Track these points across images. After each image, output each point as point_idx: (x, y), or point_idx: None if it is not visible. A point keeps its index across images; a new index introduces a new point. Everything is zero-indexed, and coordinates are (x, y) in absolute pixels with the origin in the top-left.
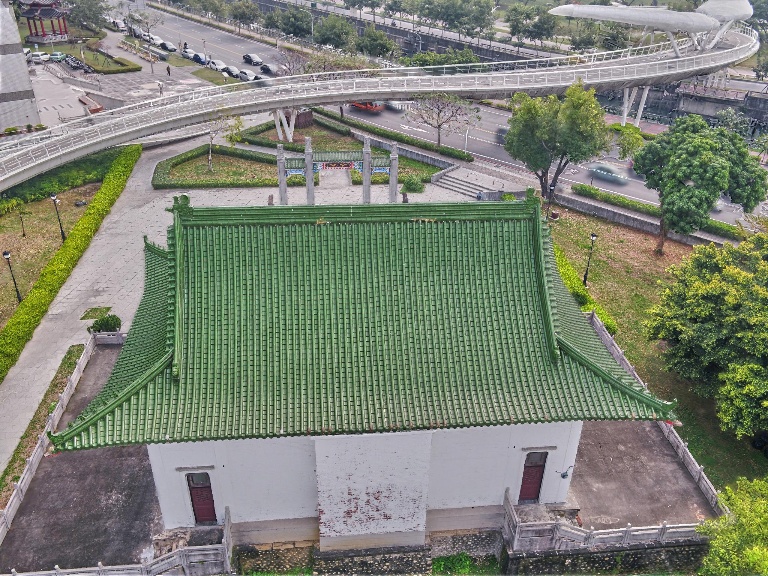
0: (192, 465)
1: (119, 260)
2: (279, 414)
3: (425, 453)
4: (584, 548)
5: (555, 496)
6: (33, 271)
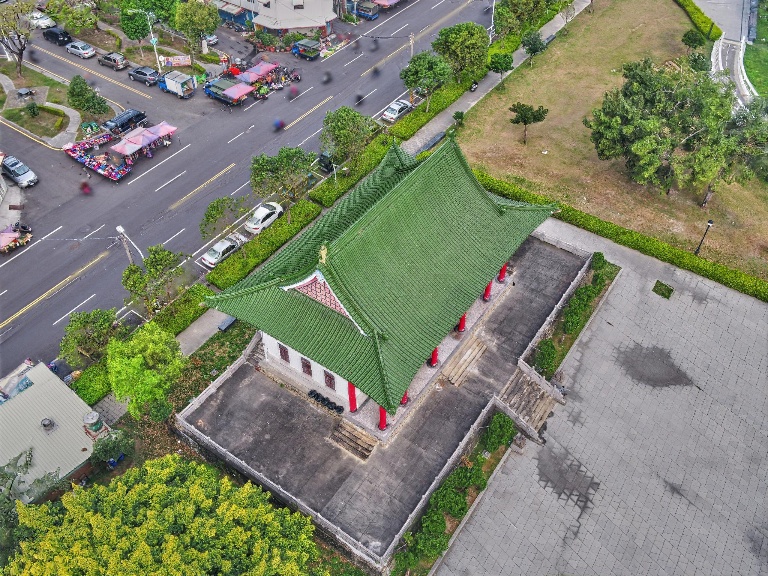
0: None
1: (760, 327)
2: (355, 198)
3: None
4: None
5: None
6: (763, 277)
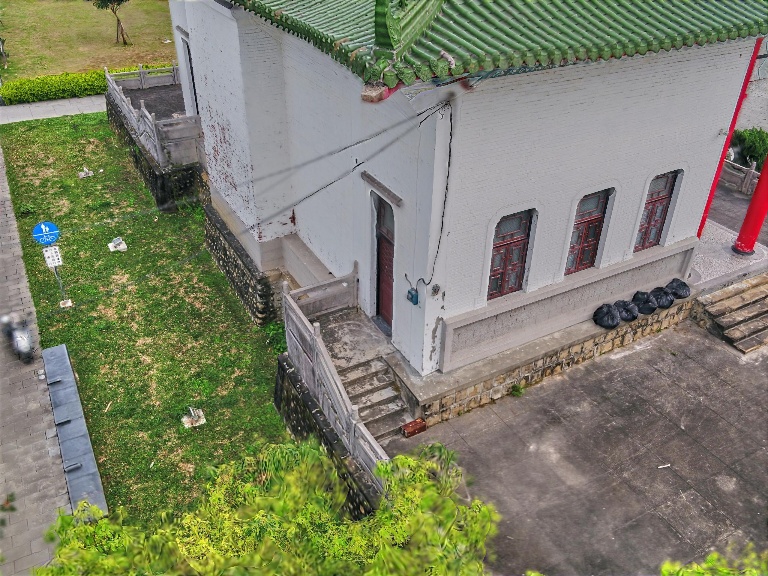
0: (183, 26)
1: None
2: None
3: (238, 69)
4: (346, 446)
5: (409, 344)
6: None
